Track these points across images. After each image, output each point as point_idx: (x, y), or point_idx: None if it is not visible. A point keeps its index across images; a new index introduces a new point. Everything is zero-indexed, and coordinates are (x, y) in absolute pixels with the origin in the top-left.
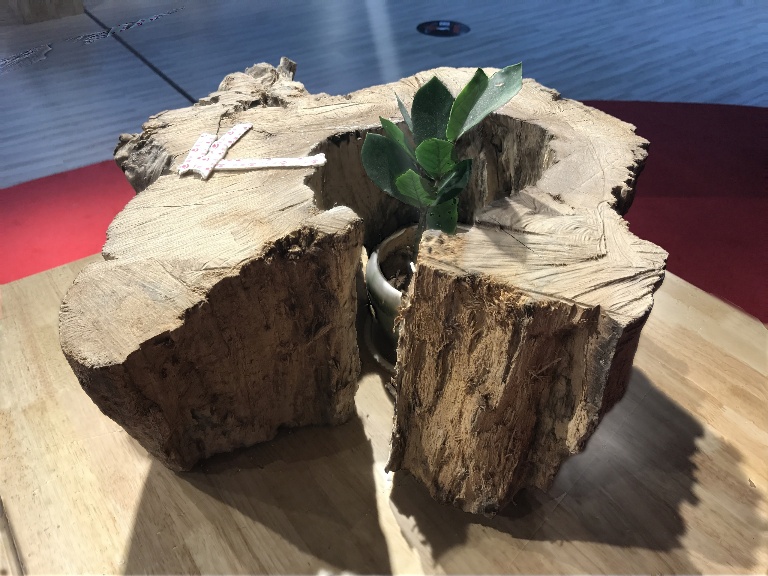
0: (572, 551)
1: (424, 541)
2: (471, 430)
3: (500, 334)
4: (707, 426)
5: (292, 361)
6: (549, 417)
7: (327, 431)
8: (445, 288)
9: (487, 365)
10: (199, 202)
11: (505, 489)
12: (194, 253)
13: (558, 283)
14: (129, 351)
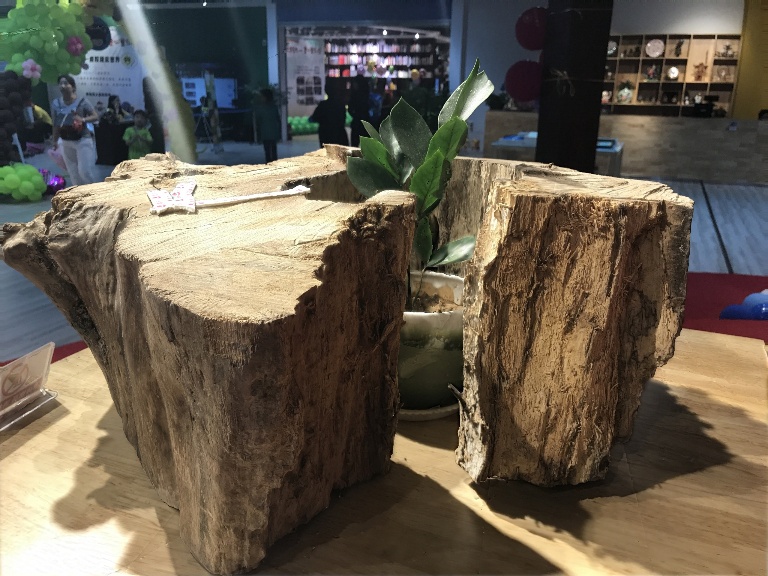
0: (672, 488)
1: (557, 530)
2: (586, 362)
3: (601, 244)
4: (666, 382)
5: (352, 382)
6: (628, 342)
7: (376, 484)
8: (544, 213)
9: (585, 289)
10: (212, 222)
11: (613, 433)
12: (270, 238)
13: (624, 193)
14: (291, 305)
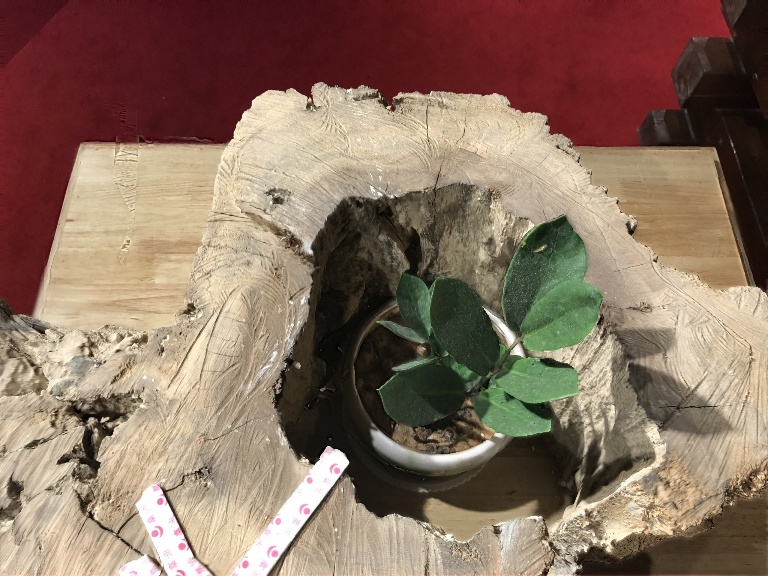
0: None
1: None
2: None
3: None
4: None
5: None
6: None
7: None
8: None
9: None
10: None
11: None
12: None
13: None
14: None
